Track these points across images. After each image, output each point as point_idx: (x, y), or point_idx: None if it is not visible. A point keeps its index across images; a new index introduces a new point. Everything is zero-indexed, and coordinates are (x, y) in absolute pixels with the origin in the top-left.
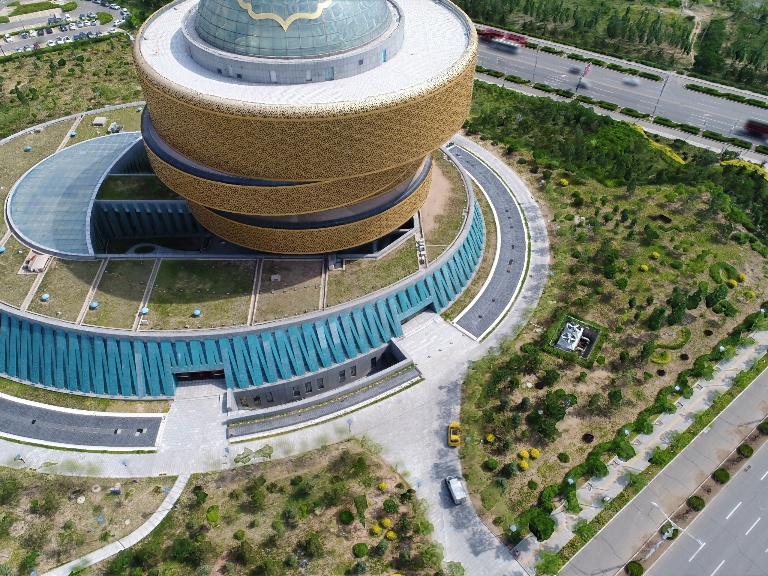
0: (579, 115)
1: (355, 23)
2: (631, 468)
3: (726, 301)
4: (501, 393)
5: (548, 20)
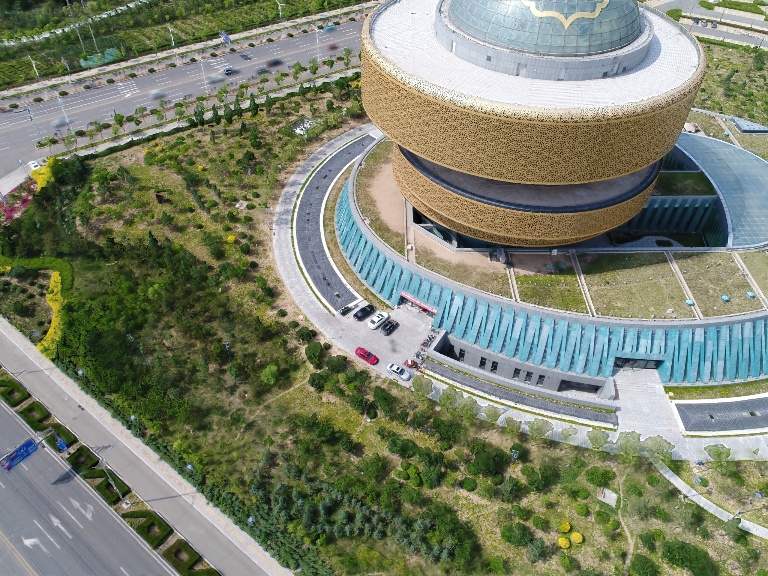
0: None
1: None
2: (307, 84)
3: (180, 138)
4: None
5: None
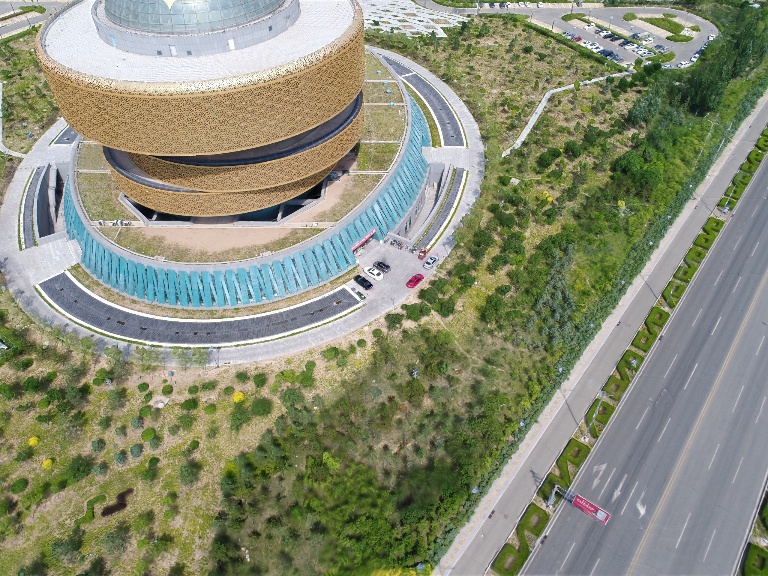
0: (433, 469)
1: (116, 2)
2: None
3: None
4: None
5: None
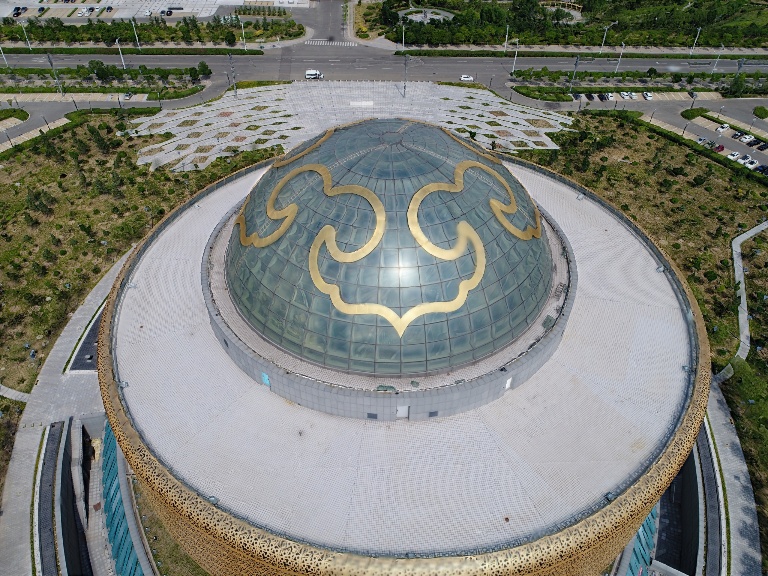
0: None
1: (271, 302)
2: None
3: None
4: None
5: None
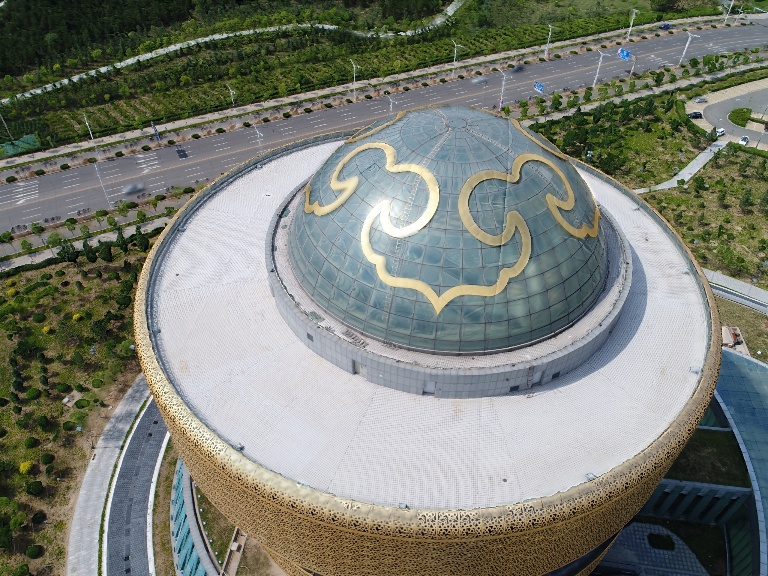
0: None
1: None
2: None
3: (44, 277)
4: None
5: None
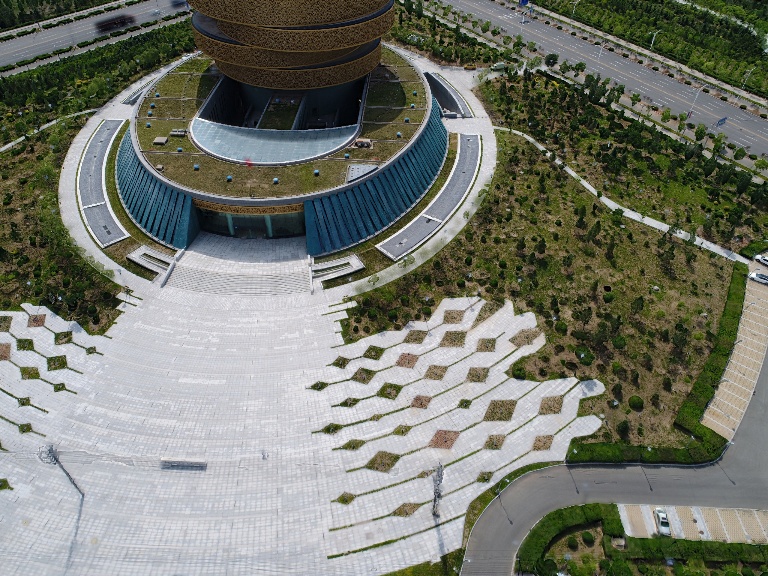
0: None
1: None
2: None
3: None
4: (448, 56)
5: (60, 0)
